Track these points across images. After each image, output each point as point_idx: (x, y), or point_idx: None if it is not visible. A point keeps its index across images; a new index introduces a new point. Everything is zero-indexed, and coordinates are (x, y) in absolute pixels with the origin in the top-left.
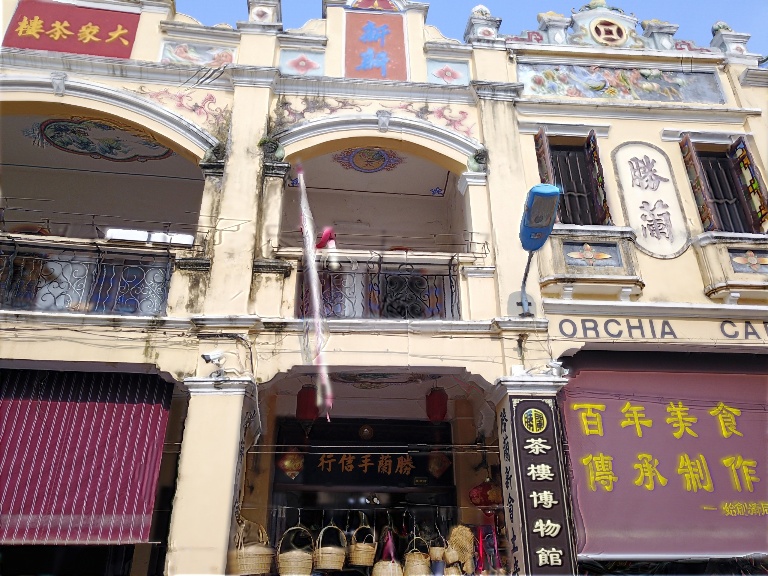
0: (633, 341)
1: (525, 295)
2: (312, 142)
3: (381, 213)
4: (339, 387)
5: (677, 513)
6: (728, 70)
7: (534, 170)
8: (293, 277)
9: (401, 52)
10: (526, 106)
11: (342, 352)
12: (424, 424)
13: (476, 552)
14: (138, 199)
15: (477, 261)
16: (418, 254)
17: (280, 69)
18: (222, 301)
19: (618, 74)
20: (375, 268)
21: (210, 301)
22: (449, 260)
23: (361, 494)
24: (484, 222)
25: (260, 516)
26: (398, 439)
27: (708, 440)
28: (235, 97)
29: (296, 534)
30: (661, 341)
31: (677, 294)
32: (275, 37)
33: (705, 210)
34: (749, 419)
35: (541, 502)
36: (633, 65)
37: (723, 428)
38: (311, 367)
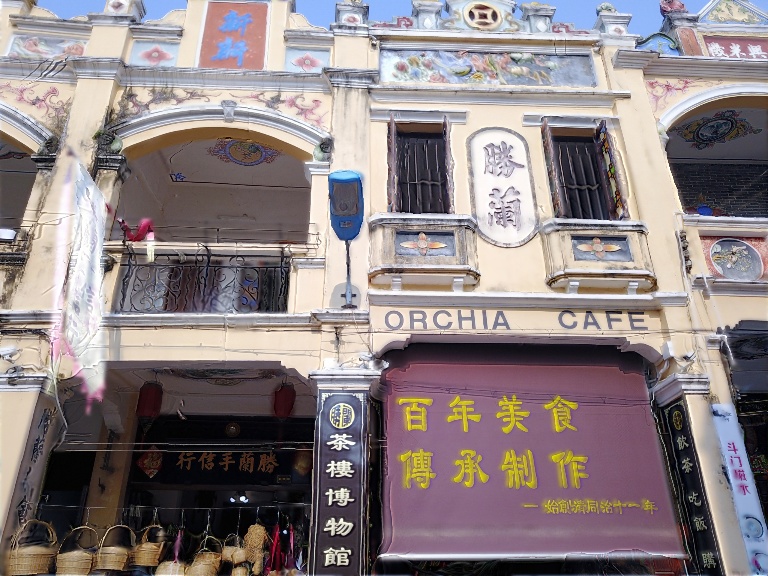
0: (461, 333)
1: (350, 286)
2: (153, 134)
3: (268, 207)
4: (190, 383)
5: (495, 511)
6: (602, 52)
7: (383, 158)
8: (115, 271)
9: (261, 41)
10: (382, 93)
11: (151, 347)
12: (294, 421)
13: (267, 552)
14: (17, 196)
15: (309, 252)
16: (247, 246)
17: (131, 61)
18: (32, 296)
19: (486, 59)
20: (204, 261)
21: (20, 296)
22: (280, 252)
23: (225, 492)
24: (323, 212)
25: (109, 515)
26: (265, 436)
27: (538, 435)
28: (76, 89)
29: (152, 533)
30: (492, 332)
31: (516, 284)
32: (127, 28)
33: (555, 196)
34: (586, 413)
35: (336, 500)
36: (504, 49)
37: (556, 422)
38: (118, 362)
